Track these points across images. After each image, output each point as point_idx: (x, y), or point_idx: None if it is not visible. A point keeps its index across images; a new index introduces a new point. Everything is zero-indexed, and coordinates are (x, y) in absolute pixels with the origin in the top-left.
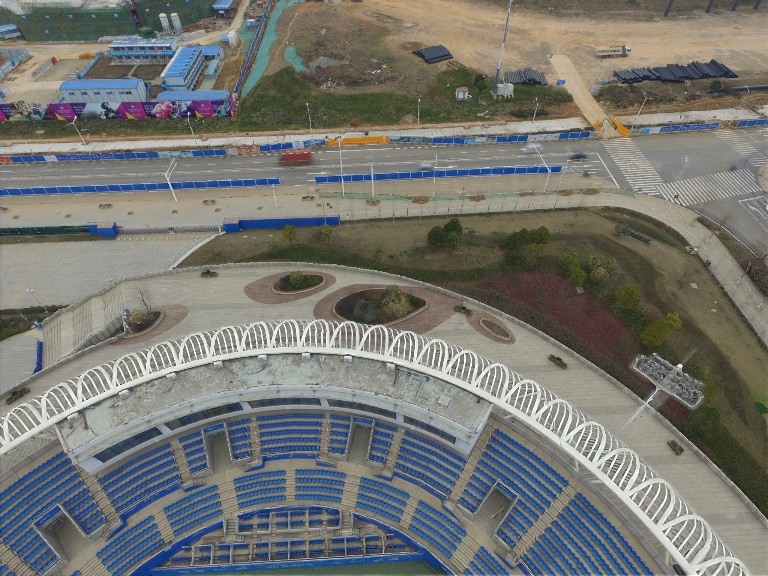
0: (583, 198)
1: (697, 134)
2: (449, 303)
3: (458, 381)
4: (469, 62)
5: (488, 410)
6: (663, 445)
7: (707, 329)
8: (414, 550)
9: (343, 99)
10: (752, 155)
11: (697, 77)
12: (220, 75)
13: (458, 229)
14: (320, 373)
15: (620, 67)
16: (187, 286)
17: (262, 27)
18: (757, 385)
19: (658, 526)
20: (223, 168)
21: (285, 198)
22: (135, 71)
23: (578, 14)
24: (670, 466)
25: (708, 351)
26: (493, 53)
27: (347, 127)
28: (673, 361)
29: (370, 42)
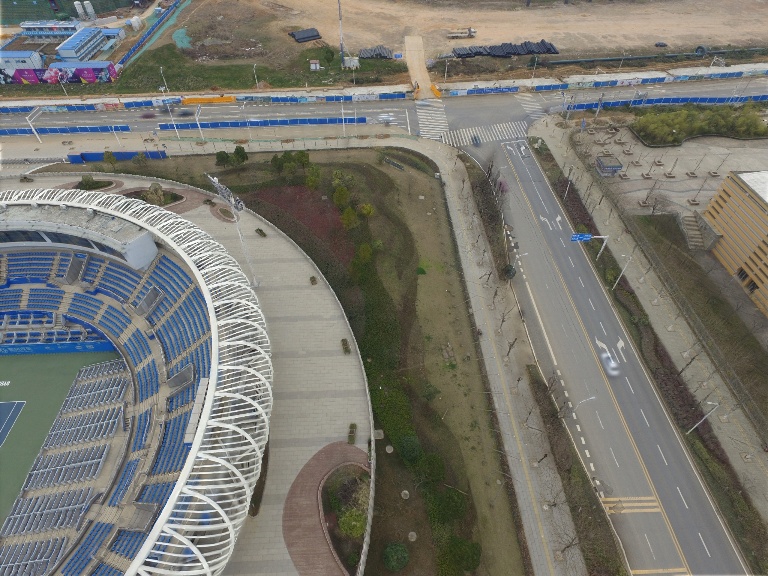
0: (374, 141)
1: (500, 96)
2: (202, 199)
3: (131, 218)
4: (334, 42)
5: (143, 234)
6: (306, 279)
7: (412, 224)
8: (102, 339)
9: (211, 69)
10: (535, 111)
11: (523, 53)
12: (115, 51)
13: (240, 154)
14: (40, 215)
15: (463, 46)
16: (6, 188)
17: (169, 15)
18: (427, 258)
19: (208, 286)
20: (88, 119)
21: (131, 140)
22: (43, 48)
23: (451, 4)
24: (303, 291)
25: (401, 236)
26: (358, 35)
27: (207, 91)
28: (367, 241)
29: (256, 26)
